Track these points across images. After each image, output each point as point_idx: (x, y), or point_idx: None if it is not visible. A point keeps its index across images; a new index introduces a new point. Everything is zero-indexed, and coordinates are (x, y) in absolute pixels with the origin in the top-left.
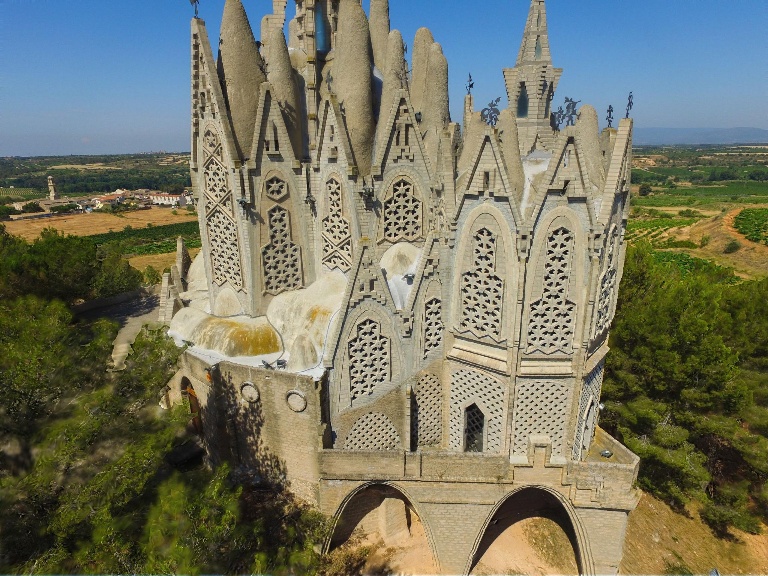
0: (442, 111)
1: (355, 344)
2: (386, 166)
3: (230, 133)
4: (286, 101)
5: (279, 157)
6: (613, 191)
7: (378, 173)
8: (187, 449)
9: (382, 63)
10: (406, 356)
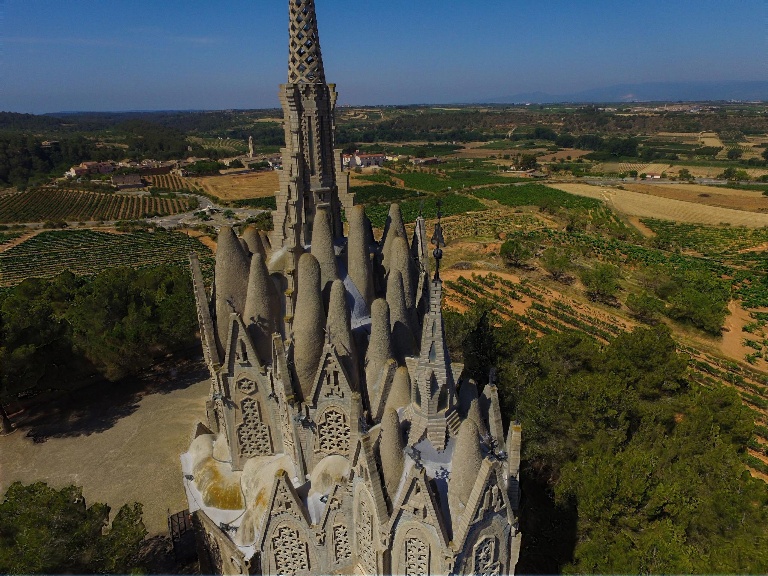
0: (381, 348)
1: (278, 540)
2: (319, 399)
3: (213, 341)
4: (259, 315)
5: (248, 364)
6: (467, 523)
7: (311, 405)
8: (189, 547)
9: (354, 272)
10: (321, 558)
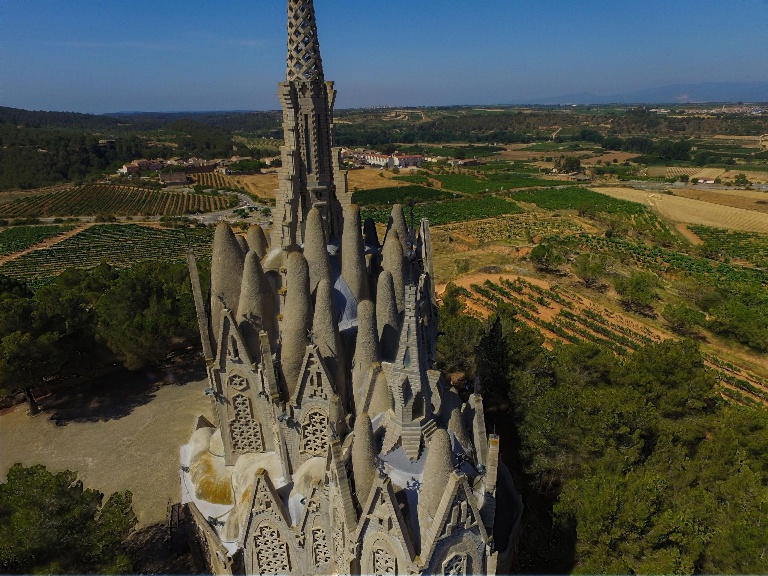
0: (367, 351)
1: (260, 538)
2: (303, 399)
3: (207, 337)
4: (251, 313)
5: (239, 361)
6: (433, 539)
7: (294, 405)
8: (185, 537)
9: (347, 273)
10: (301, 560)
